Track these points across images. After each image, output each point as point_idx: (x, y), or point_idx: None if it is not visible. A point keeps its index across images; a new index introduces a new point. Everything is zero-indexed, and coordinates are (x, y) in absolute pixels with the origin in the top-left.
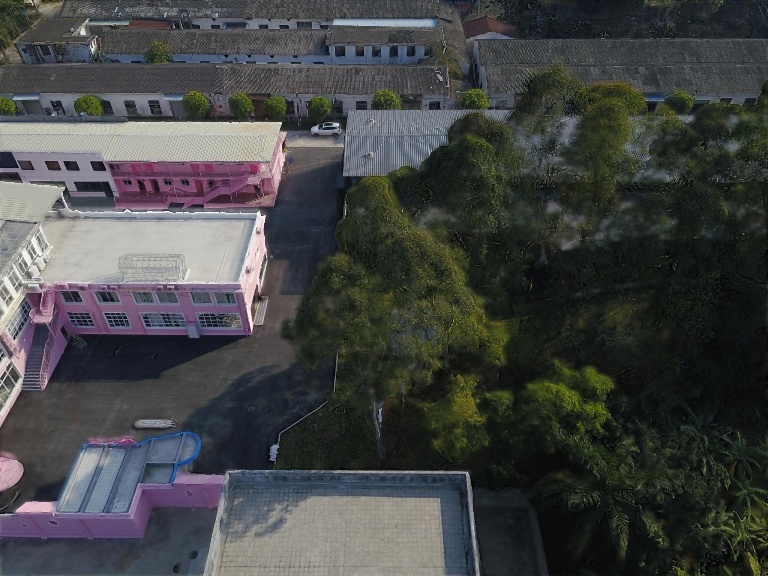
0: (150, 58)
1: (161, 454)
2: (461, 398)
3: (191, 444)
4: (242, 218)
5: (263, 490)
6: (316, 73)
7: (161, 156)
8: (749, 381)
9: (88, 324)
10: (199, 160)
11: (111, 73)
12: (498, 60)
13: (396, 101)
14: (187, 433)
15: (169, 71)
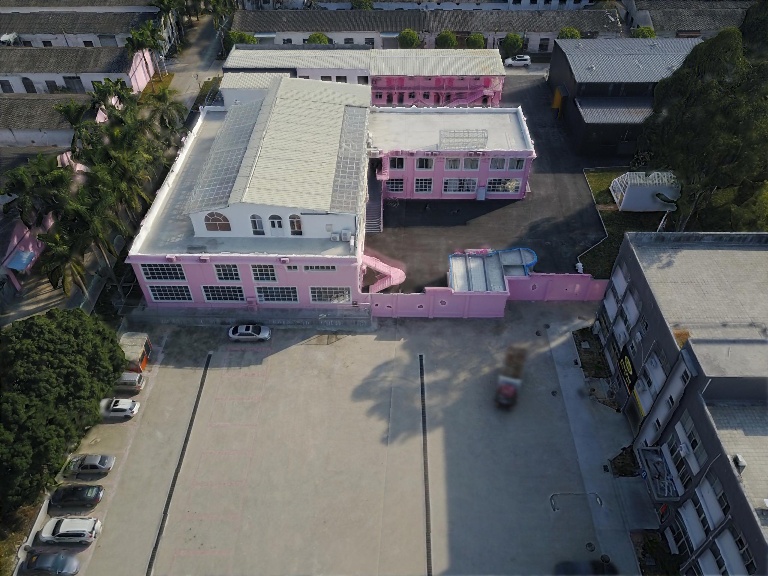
0: (358, 5)
1: (509, 261)
2: None
3: (528, 255)
4: (505, 112)
5: (648, 247)
6: (505, 15)
7: (415, 72)
8: None
9: (398, 189)
10: (448, 74)
11: (332, 16)
12: (652, 6)
13: (579, 36)
14: (522, 248)
15: (381, 14)
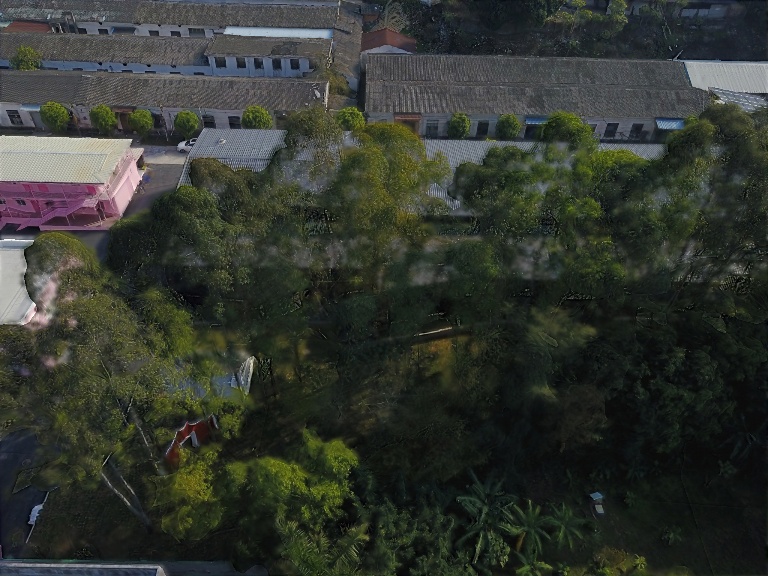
0: (16, 64)
1: None
2: (183, 474)
3: None
4: None
5: None
6: (188, 85)
7: None
8: (549, 443)
9: None
10: (28, 180)
11: None
12: (386, 76)
13: (266, 118)
14: None
15: (31, 79)
